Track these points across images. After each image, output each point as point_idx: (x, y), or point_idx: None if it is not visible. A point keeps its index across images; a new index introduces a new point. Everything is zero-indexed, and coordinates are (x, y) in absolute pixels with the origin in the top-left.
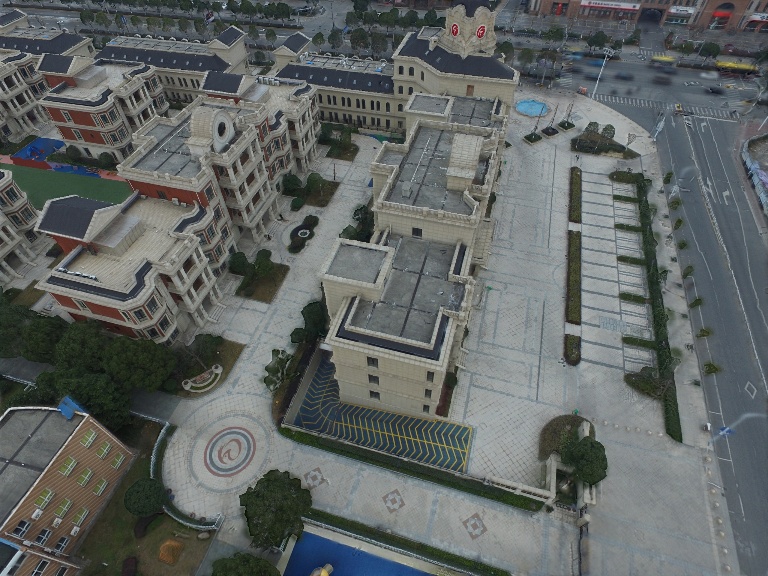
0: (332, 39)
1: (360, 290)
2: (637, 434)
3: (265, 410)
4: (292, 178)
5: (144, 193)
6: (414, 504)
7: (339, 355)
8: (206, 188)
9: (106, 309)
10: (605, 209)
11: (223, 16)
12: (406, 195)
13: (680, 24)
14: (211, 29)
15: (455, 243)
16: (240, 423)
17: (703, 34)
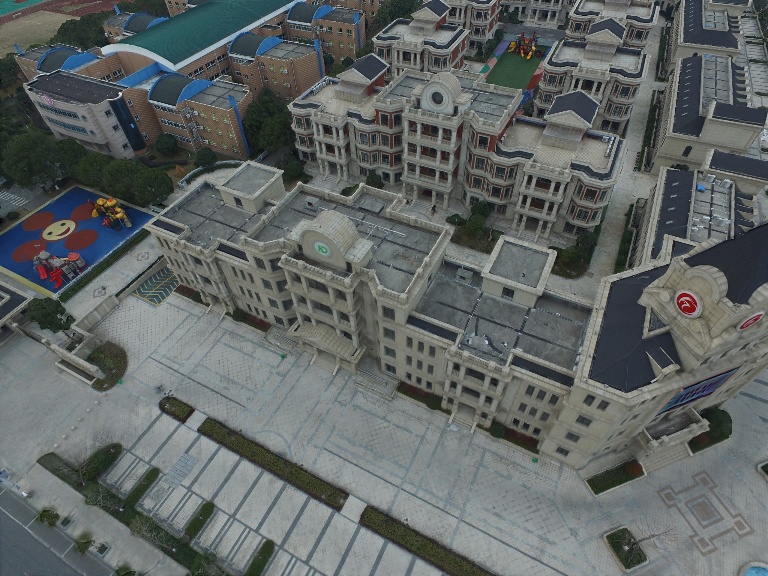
0: None
1: None
2: None
3: None
4: (479, 205)
5: None
6: (134, 265)
7: None
8: (383, 113)
9: None
10: None
11: None
12: None
13: None
14: None
15: None
16: None
17: None
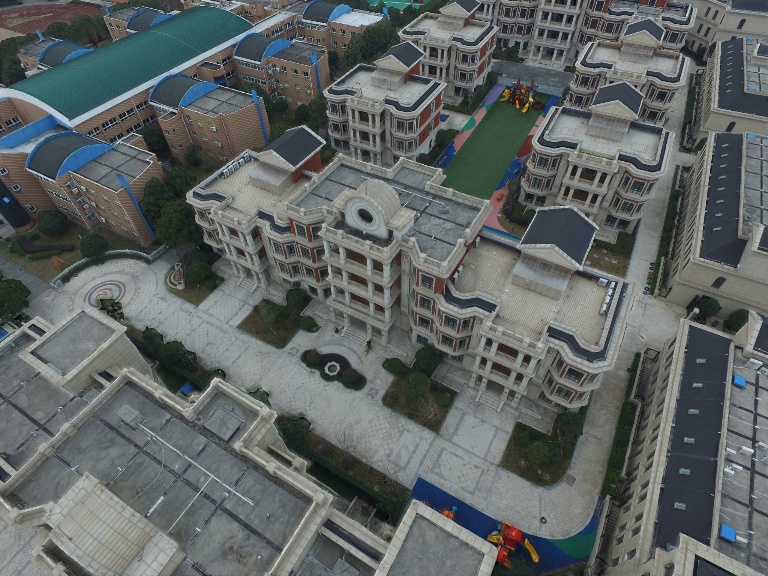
0: None
1: None
2: None
3: None
4: (425, 353)
5: None
6: None
7: None
8: (297, 223)
9: None
10: None
11: None
12: None
13: None
14: None
15: None
16: (123, 301)
17: None
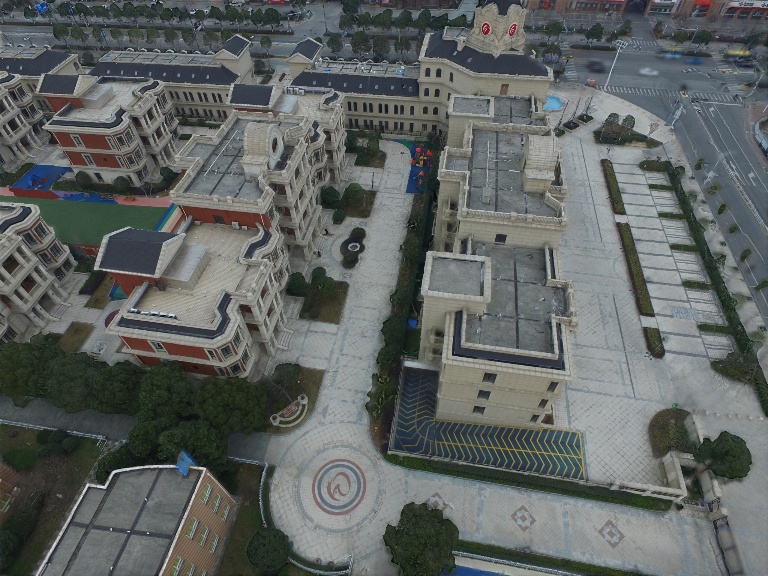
0: (332, 43)
1: (466, 304)
2: (739, 421)
3: (365, 438)
4: (331, 190)
5: (198, 219)
6: (545, 519)
7: (452, 374)
8: (269, 209)
9: (188, 349)
10: (644, 199)
11: (205, 24)
12: (486, 201)
13: (663, 13)
14: (200, 39)
15: (541, 246)
16: (342, 455)
17: (686, 22)
